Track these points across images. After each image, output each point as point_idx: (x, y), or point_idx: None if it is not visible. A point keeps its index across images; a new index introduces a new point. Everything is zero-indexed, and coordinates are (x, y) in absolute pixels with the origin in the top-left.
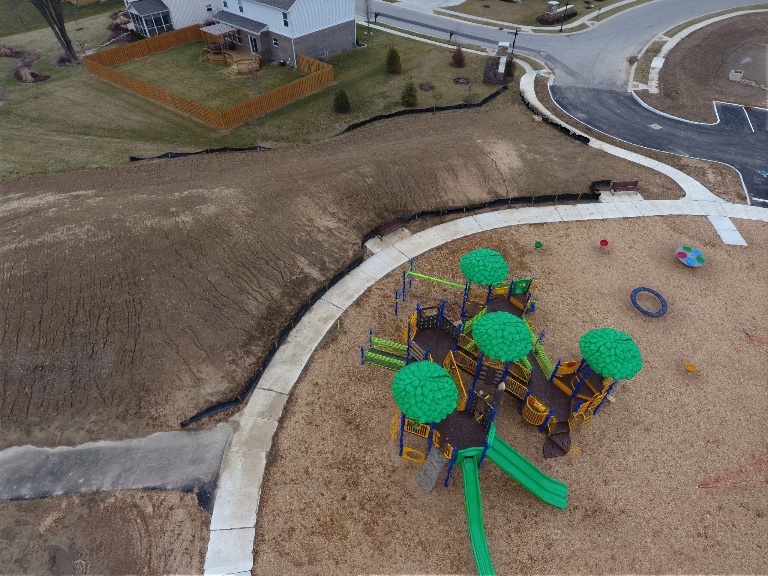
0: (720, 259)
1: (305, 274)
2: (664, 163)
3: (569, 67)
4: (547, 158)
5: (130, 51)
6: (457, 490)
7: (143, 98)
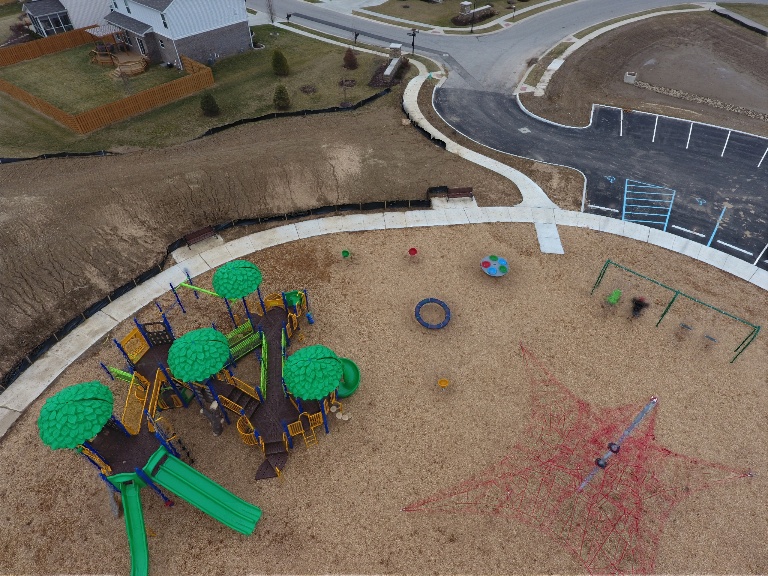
0: (529, 268)
1: (91, 285)
2: (514, 168)
3: (465, 69)
4: (391, 163)
5: (19, 53)
6: (150, 514)
7: (15, 101)
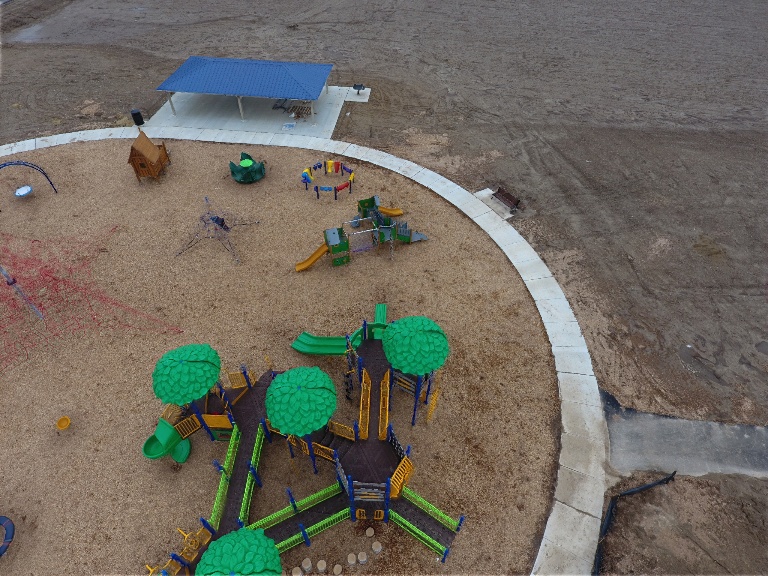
0: None
1: None
2: None
3: None
4: None
5: None
6: None
7: None
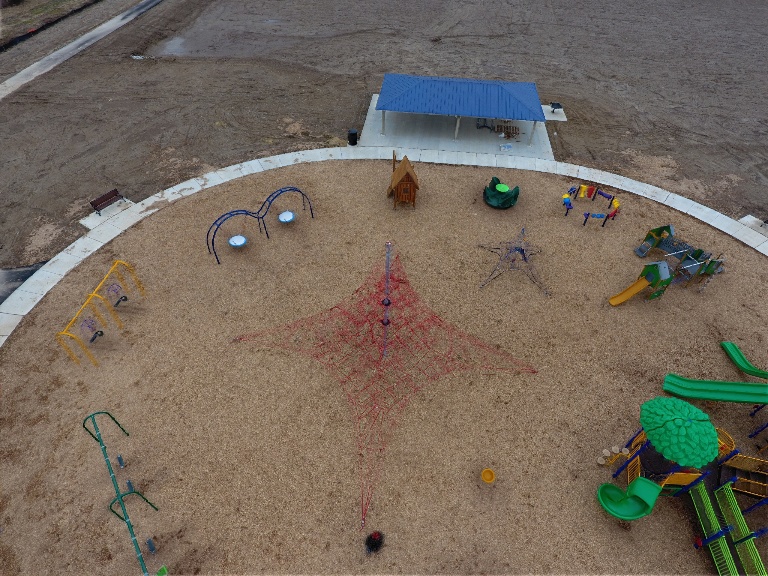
0: None
1: None
2: None
3: None
4: None
5: None
6: (767, 411)
7: None
